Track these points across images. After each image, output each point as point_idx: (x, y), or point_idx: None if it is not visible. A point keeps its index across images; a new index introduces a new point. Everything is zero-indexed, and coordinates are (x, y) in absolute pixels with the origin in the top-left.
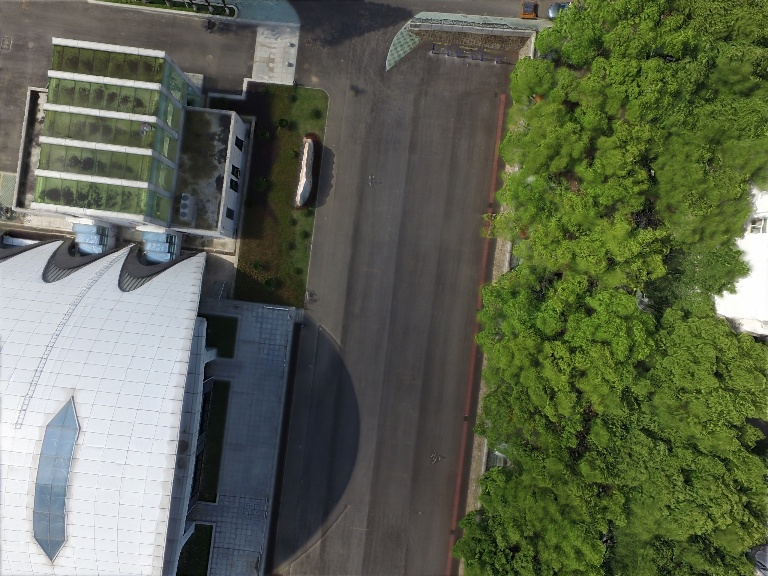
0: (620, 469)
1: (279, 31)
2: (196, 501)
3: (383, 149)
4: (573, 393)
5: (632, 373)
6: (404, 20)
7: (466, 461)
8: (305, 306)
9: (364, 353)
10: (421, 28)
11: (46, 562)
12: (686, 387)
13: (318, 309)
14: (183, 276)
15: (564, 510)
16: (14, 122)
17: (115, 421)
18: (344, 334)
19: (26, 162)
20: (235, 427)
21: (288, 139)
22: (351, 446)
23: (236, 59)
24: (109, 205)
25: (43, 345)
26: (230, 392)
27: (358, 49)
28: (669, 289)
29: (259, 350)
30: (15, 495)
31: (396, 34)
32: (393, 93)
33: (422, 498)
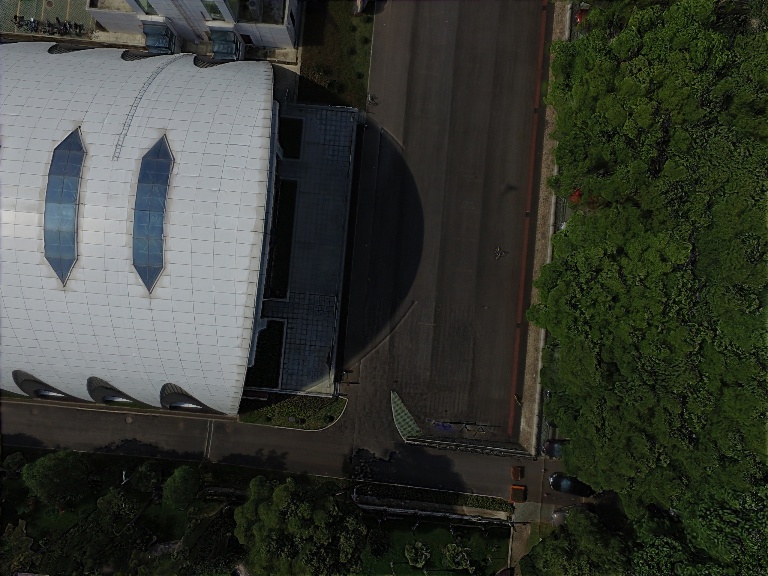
0: (702, 174)
1: None
2: (268, 297)
3: None
4: (653, 101)
5: (712, 72)
6: None
7: (529, 256)
8: (367, 109)
9: (426, 153)
10: None
11: (143, 294)
12: (765, 86)
13: (380, 112)
14: (254, 64)
15: (646, 222)
16: None
17: (207, 154)
18: (406, 136)
19: None
20: (303, 226)
21: None
22: (416, 244)
23: None
24: None
25: (132, 96)
26: (297, 192)
27: None
28: (733, 39)
29: (324, 151)
30: (115, 222)
31: None
32: None
33: (487, 293)
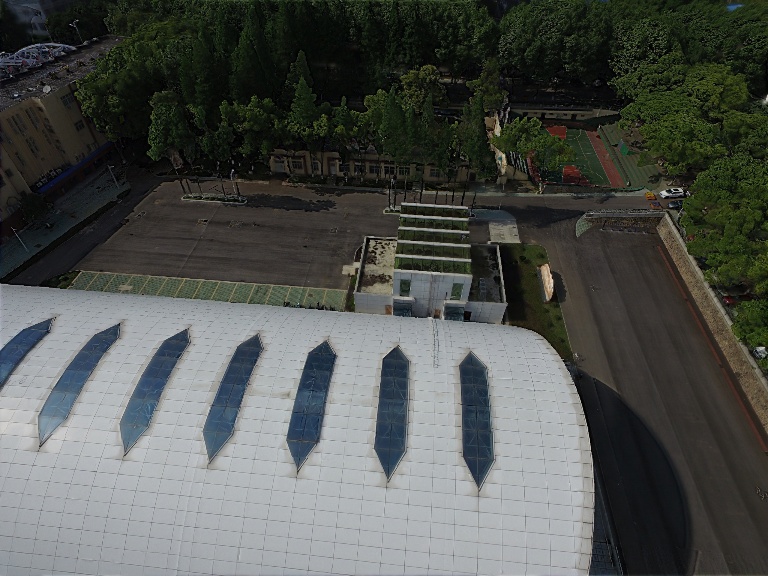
0: None
1: (503, 223)
2: None
3: (593, 272)
4: None
5: None
6: (580, 215)
7: None
8: (576, 364)
9: (641, 398)
10: (593, 217)
11: (471, 492)
12: None
13: (587, 366)
14: None
15: None
16: (337, 264)
17: (513, 364)
18: (617, 384)
19: (362, 271)
20: None
21: (526, 268)
22: (670, 483)
23: (479, 235)
24: (446, 271)
25: (430, 330)
26: None
27: (556, 228)
28: None
29: None
30: (444, 415)
31: (577, 221)
32: (586, 246)
33: None
